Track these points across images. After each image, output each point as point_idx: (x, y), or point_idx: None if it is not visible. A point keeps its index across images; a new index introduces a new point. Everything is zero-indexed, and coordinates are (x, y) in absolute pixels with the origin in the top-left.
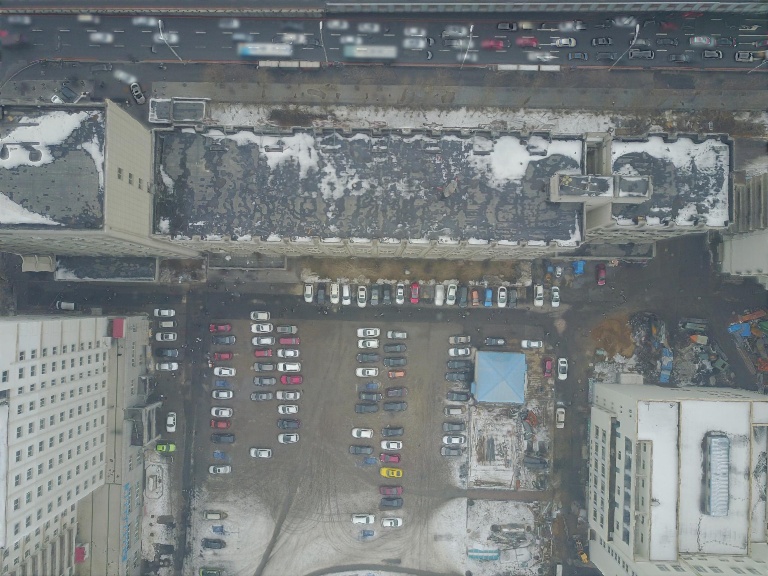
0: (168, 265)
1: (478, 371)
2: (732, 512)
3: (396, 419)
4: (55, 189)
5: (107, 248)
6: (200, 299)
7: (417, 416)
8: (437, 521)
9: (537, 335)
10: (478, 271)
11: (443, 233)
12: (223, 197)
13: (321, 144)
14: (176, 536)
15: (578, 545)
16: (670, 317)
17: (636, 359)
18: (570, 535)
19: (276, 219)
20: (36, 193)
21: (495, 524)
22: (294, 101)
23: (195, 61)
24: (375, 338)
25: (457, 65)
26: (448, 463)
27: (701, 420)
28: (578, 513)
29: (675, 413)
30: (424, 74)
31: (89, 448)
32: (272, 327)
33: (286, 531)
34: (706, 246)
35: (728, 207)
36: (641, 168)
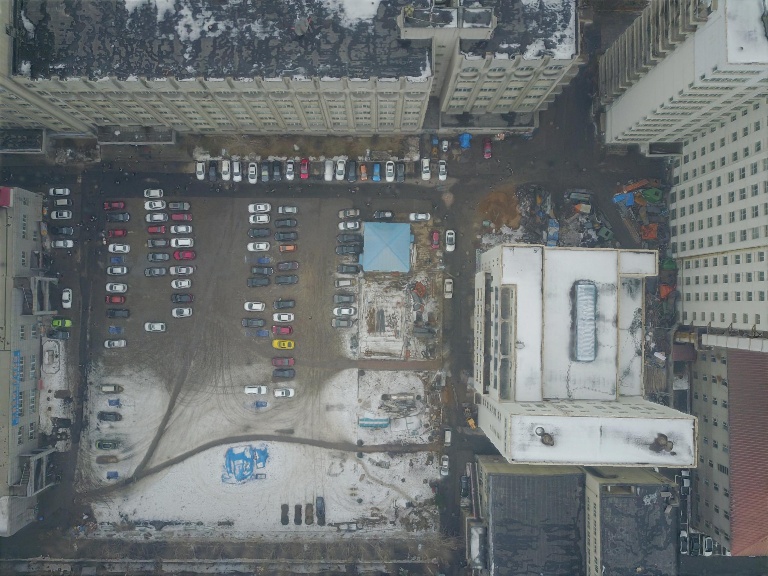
0: (63, 146)
1: (364, 240)
2: (601, 359)
3: (288, 293)
4: None
5: None
6: (95, 179)
7: (308, 289)
8: (329, 392)
9: (425, 208)
10: (367, 147)
11: (297, 72)
12: (83, 41)
13: None
14: (73, 410)
15: (466, 412)
16: (556, 189)
17: (523, 230)
18: (459, 403)
19: (135, 61)
20: None
21: (386, 394)
22: None
23: None
24: (266, 213)
25: None
26: (339, 335)
27: (569, 269)
28: (467, 381)
29: (539, 258)
30: None
31: None
32: (165, 204)
33: (181, 404)
34: (590, 119)
35: (575, 42)
36: (490, 6)
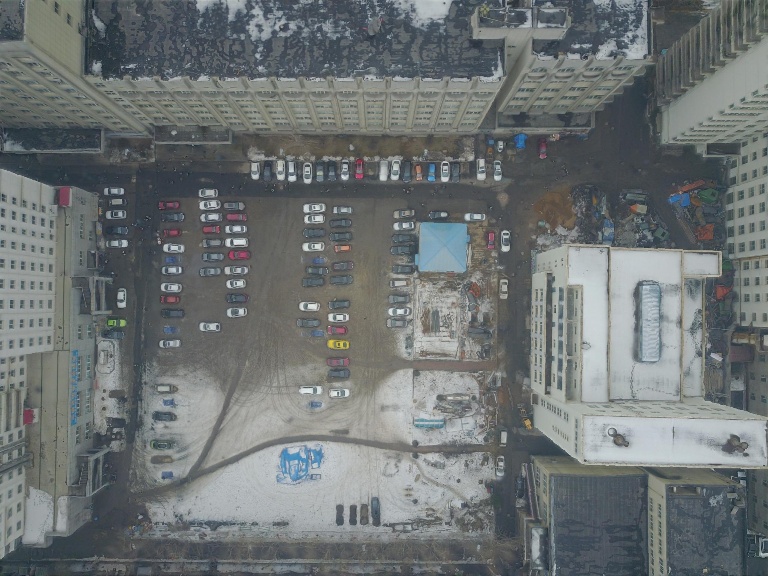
0: (117, 145)
1: (421, 241)
2: (665, 360)
3: (342, 293)
4: None
5: (46, 103)
6: (149, 178)
7: (363, 290)
8: (384, 392)
9: (480, 209)
10: (422, 147)
11: (369, 72)
12: (154, 40)
13: None
14: (128, 410)
15: (522, 412)
16: (611, 189)
17: (578, 231)
18: (515, 404)
19: (206, 61)
20: None
21: (441, 394)
22: None
23: None
24: (321, 213)
25: None
26: (394, 335)
27: (633, 270)
28: (522, 382)
29: (605, 258)
30: None
31: (35, 307)
32: (219, 204)
33: (236, 404)
34: (646, 119)
35: (647, 42)
36: (562, 6)
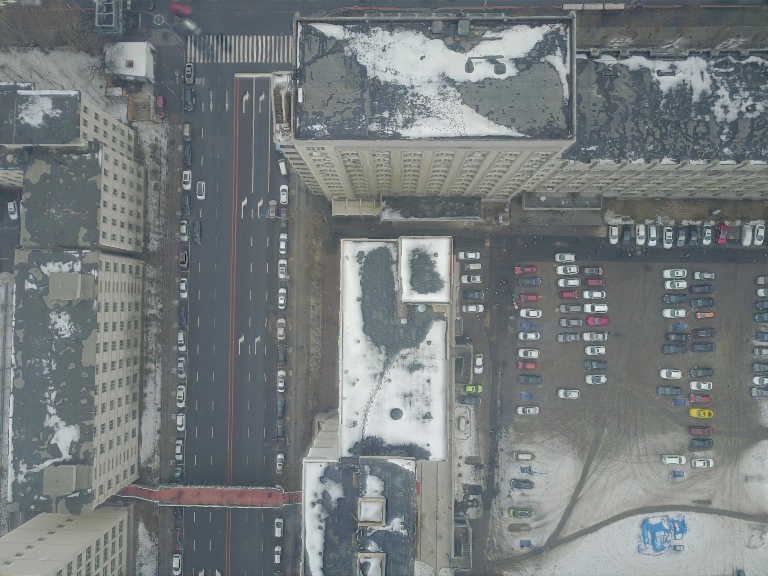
0: None
1: None
2: None
3: (703, 360)
4: (520, 101)
5: (473, 179)
6: (503, 242)
7: (725, 357)
8: (748, 462)
9: None
10: None
11: None
12: (615, 122)
13: (713, 67)
14: (484, 477)
15: None
16: None
17: None
18: None
19: (669, 143)
20: (501, 105)
21: None
22: (594, 44)
23: (493, 7)
24: (682, 279)
25: (758, 5)
26: (758, 404)
27: None
28: None
29: None
30: (725, 15)
31: None
32: (578, 269)
33: (594, 472)
34: None
35: None
36: None
